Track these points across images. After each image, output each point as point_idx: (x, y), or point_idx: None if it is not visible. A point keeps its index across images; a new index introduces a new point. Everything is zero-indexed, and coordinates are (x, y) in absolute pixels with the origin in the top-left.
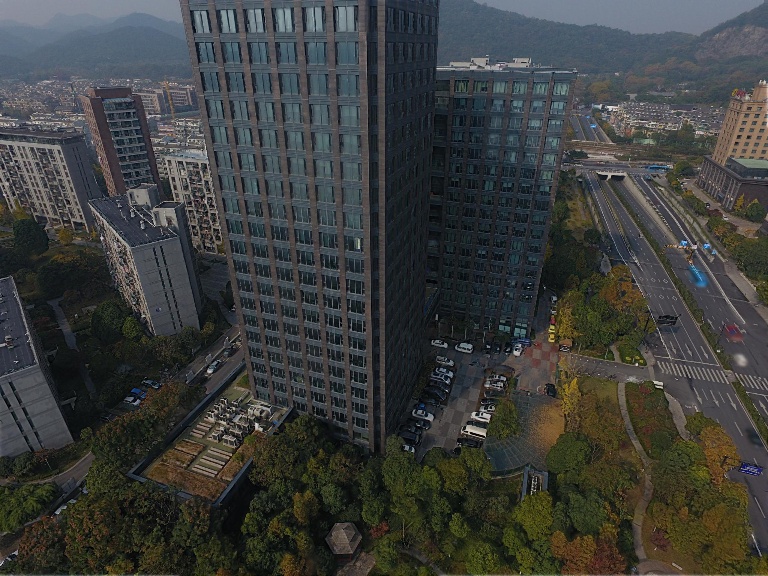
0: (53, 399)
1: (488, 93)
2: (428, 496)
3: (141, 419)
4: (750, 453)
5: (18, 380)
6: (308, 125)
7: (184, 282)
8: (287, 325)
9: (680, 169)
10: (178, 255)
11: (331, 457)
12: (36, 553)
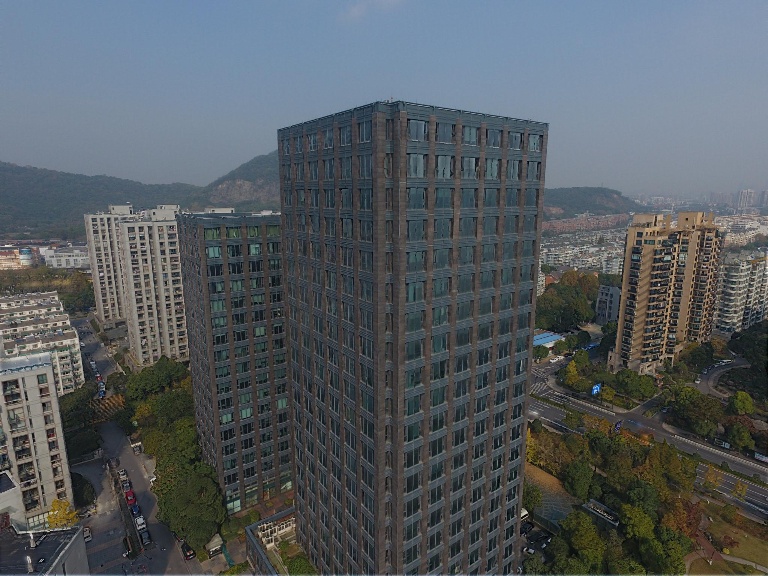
0: None
1: None
2: (601, 574)
3: None
4: None
5: None
6: (500, 263)
7: None
8: (453, 503)
9: None
10: (81, 565)
11: None
12: None
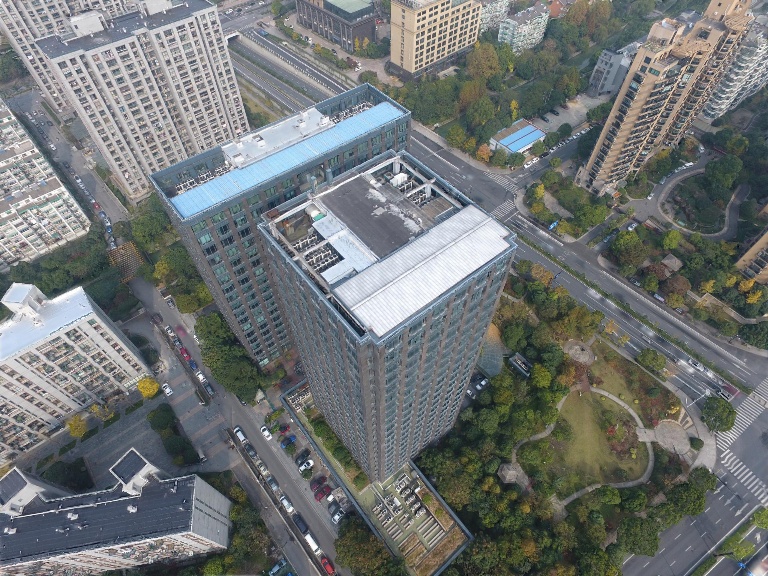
0: None
1: (355, 156)
2: (507, 417)
3: (386, 573)
4: (535, 260)
5: None
6: None
7: (212, 494)
8: None
9: (278, 11)
10: (202, 486)
11: (466, 455)
12: None
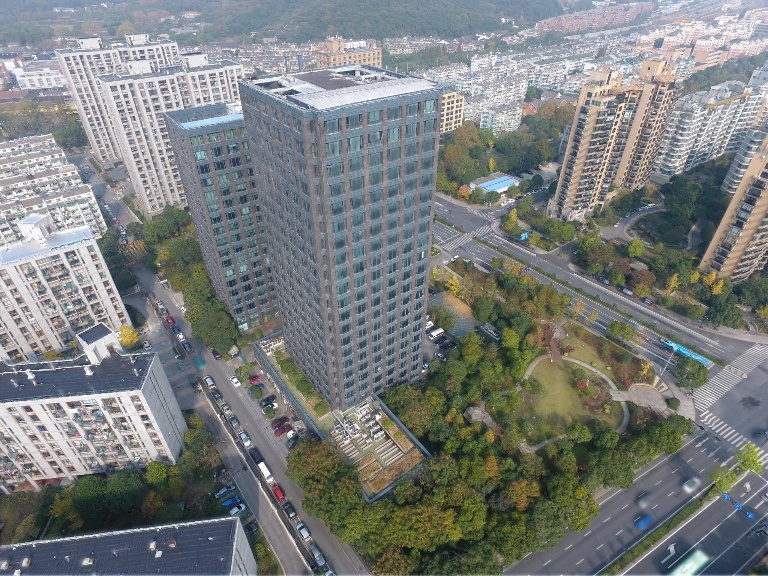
0: (246, 540)
1: None
2: (475, 369)
3: (336, 473)
4: None
5: (237, 542)
6: (403, 195)
7: (170, 393)
8: (374, 336)
9: None
10: (161, 371)
11: (431, 391)
12: (403, 572)
